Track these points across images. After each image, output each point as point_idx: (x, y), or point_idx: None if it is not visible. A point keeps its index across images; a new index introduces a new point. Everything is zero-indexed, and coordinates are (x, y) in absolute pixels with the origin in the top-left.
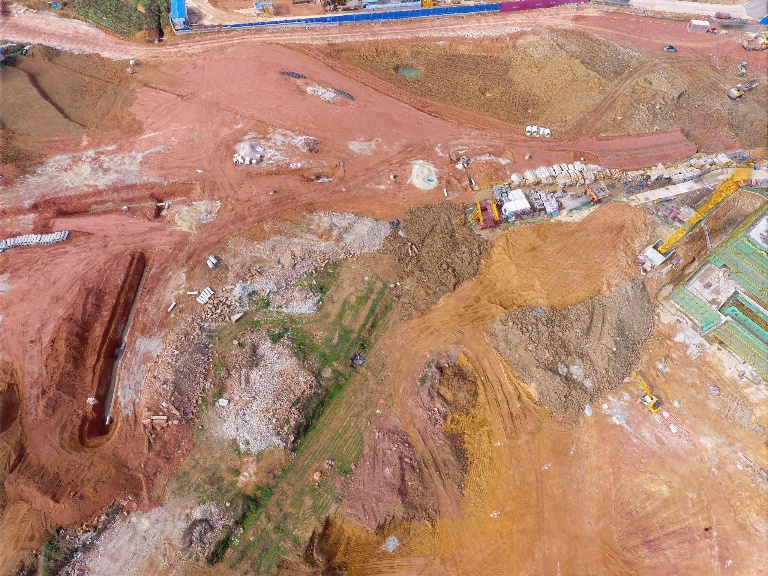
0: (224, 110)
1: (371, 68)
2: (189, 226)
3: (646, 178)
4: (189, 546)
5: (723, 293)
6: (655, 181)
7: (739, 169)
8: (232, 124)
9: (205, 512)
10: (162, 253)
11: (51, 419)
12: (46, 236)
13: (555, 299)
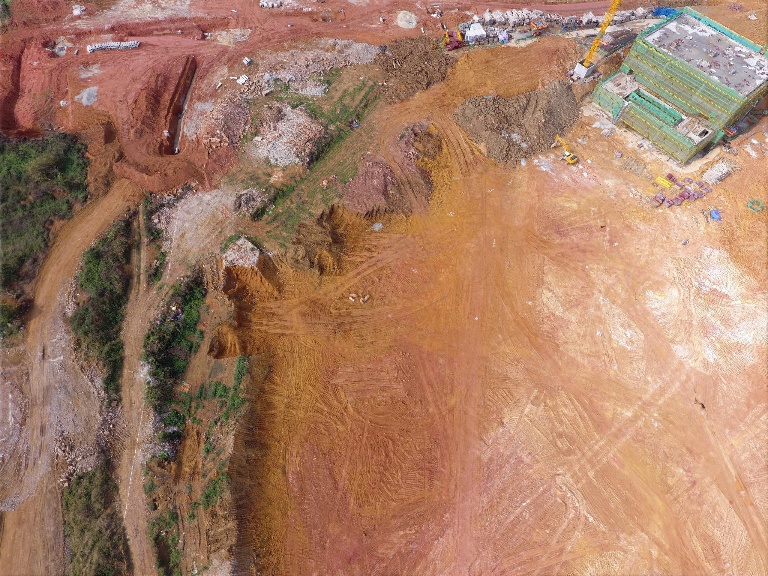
0: None
1: None
2: (228, 42)
3: (579, 22)
4: (239, 207)
5: (628, 89)
6: (586, 24)
7: (654, 20)
8: None
9: (249, 192)
10: (209, 56)
11: (139, 140)
12: (124, 43)
13: (501, 90)
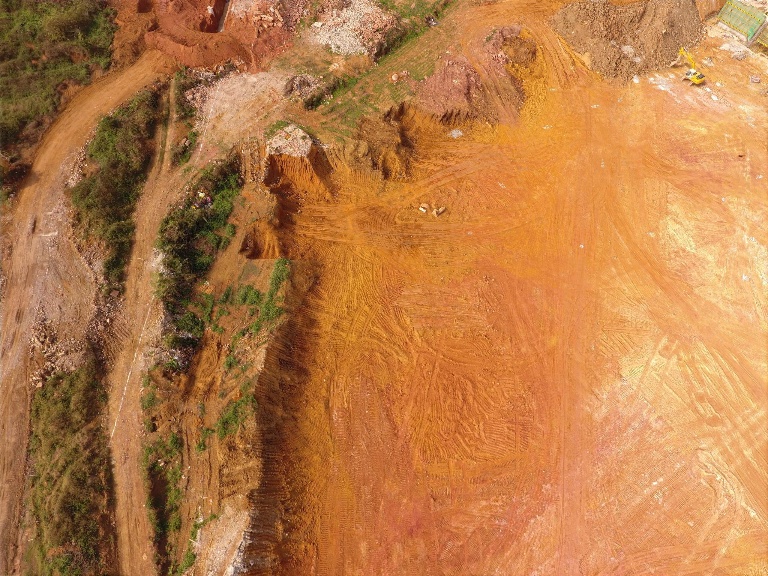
0: None
1: None
2: None
3: None
4: (290, 92)
5: None
6: None
7: None
8: None
9: (303, 76)
10: None
11: (178, 14)
12: None
13: None
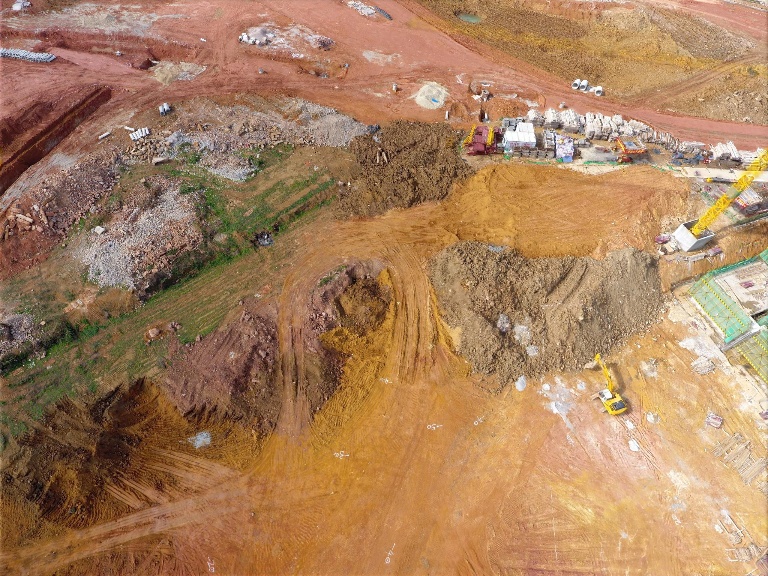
0: (257, 2)
1: (429, 6)
2: (164, 77)
3: (706, 154)
4: None
5: (767, 299)
6: (718, 160)
7: None
8: (257, 12)
9: (15, 320)
10: (125, 92)
11: None
12: (34, 54)
13: (525, 242)
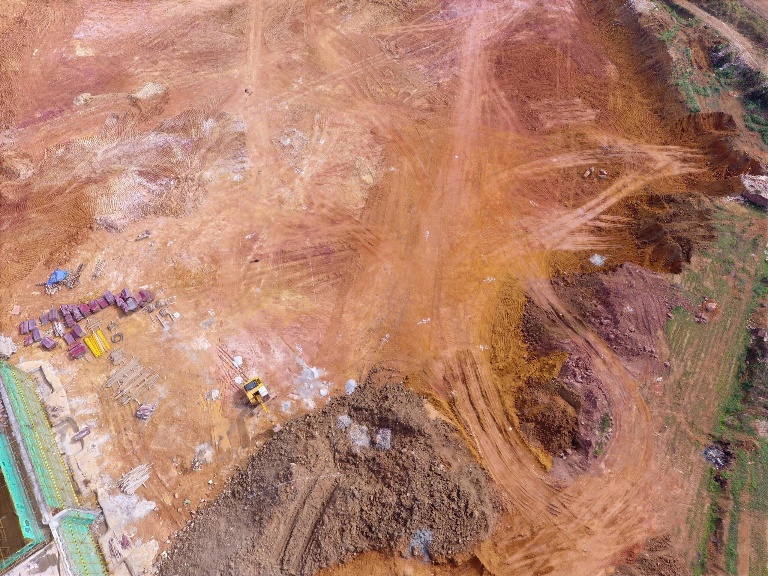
0: None
1: None
2: None
3: None
4: None
5: None
6: None
7: None
8: None
9: None
10: None
11: None
12: None
13: (381, 574)
